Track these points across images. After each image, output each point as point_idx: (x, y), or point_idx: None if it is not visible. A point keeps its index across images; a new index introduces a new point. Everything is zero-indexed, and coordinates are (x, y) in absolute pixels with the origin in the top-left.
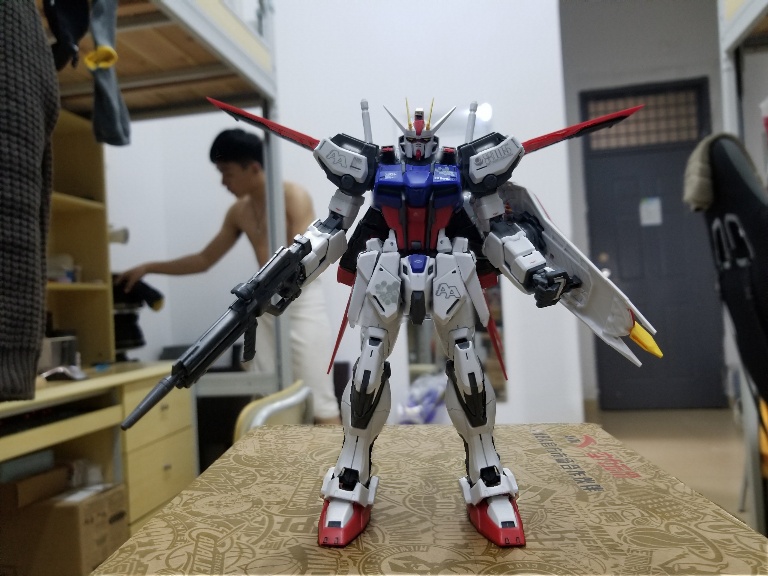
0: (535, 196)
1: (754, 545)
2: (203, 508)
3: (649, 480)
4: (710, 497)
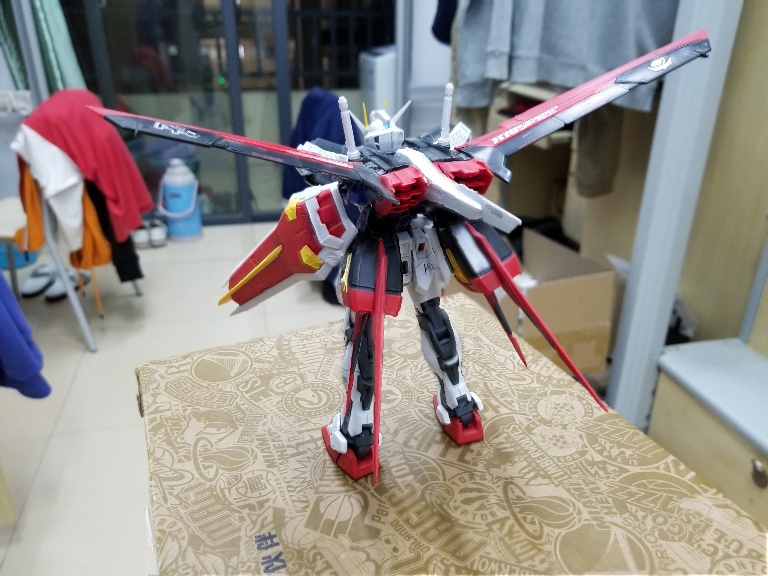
0: (288, 204)
1: (166, 456)
2: (563, 399)
3: (198, 571)
4: (149, 543)
